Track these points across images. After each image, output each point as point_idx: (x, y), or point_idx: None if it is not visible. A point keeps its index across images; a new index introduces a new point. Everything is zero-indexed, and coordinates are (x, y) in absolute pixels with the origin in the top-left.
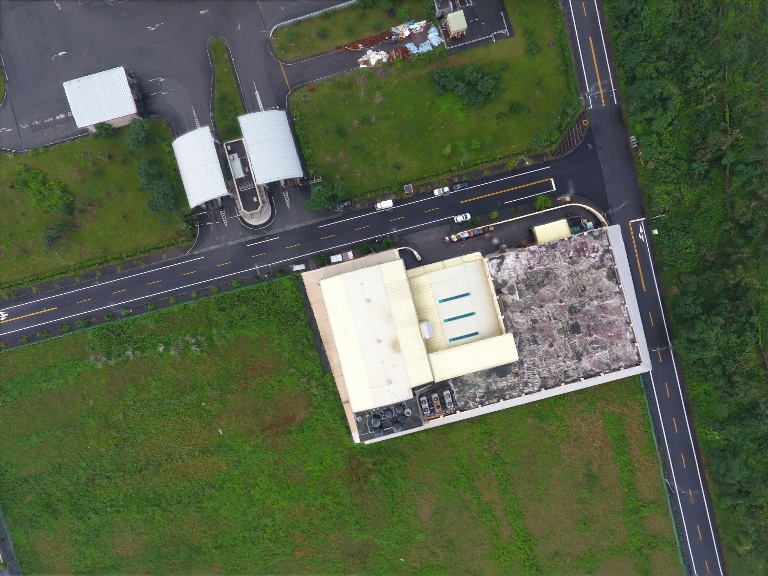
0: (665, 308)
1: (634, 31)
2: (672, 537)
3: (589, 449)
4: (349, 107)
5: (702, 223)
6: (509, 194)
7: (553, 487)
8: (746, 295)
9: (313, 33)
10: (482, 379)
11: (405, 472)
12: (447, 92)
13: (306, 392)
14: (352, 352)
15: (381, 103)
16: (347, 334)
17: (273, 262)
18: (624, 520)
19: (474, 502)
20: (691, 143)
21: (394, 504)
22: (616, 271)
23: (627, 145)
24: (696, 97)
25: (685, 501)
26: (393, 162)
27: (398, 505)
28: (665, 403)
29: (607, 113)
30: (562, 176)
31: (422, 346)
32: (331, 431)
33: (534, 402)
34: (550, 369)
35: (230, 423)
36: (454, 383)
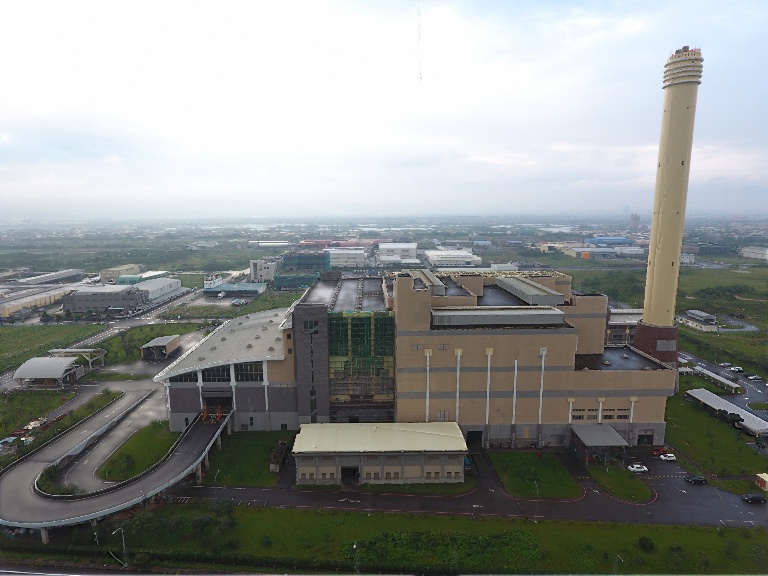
0: None
1: None
2: None
3: None
4: None
5: None
6: None
7: None
8: None
9: None
10: None
11: None
12: None
13: None
14: None
15: None
16: None
17: None
18: None
19: None
20: None
21: None
22: None
23: None
24: None
25: None
26: None
27: None
28: None
29: None
30: None
31: None
32: None
33: None
34: None
35: None
36: None
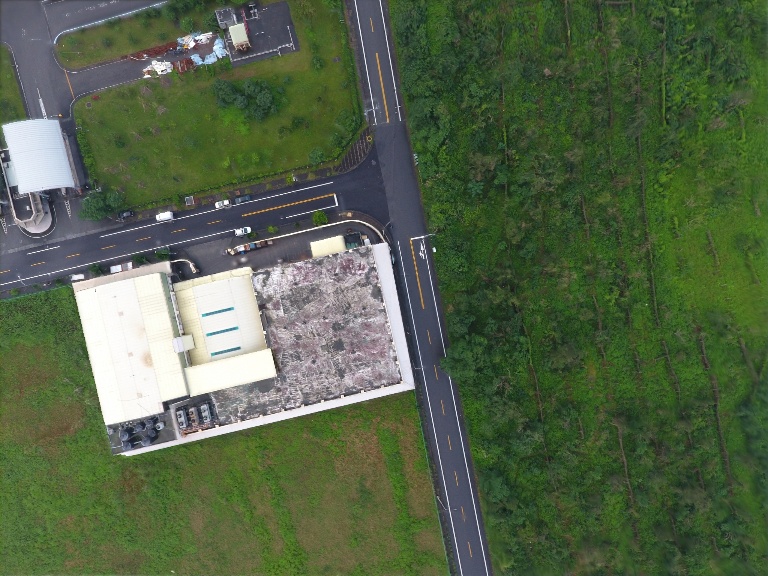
0: (443, 326)
1: (414, 49)
2: (442, 554)
3: (363, 465)
4: (132, 117)
5: (481, 242)
6: (291, 208)
7: (326, 502)
8: (514, 315)
9: (98, 41)
10: (244, 394)
11: (178, 484)
12: (230, 105)
13: (81, 402)
14: (104, 365)
15: (164, 114)
16: (100, 347)
17: (53, 271)
18: (395, 536)
19: (246, 515)
20: (468, 162)
21: (166, 516)
22: (381, 289)
23: (411, 162)
24: (473, 117)
25: (457, 518)
26: (176, 174)
27: (170, 517)
28: (440, 420)
29: (391, 130)
30: (345, 192)
31: (176, 360)
32: (105, 442)
33: (302, 417)
34: (312, 385)
35: (4, 432)
36: (216, 397)
